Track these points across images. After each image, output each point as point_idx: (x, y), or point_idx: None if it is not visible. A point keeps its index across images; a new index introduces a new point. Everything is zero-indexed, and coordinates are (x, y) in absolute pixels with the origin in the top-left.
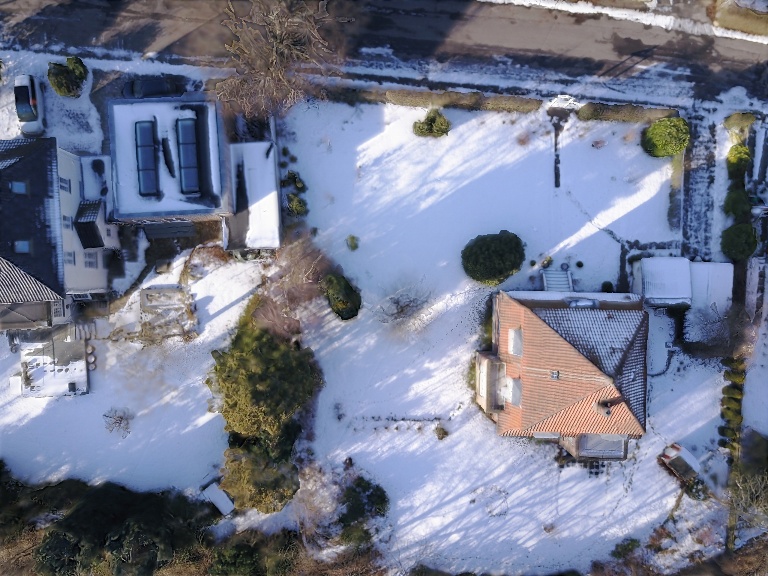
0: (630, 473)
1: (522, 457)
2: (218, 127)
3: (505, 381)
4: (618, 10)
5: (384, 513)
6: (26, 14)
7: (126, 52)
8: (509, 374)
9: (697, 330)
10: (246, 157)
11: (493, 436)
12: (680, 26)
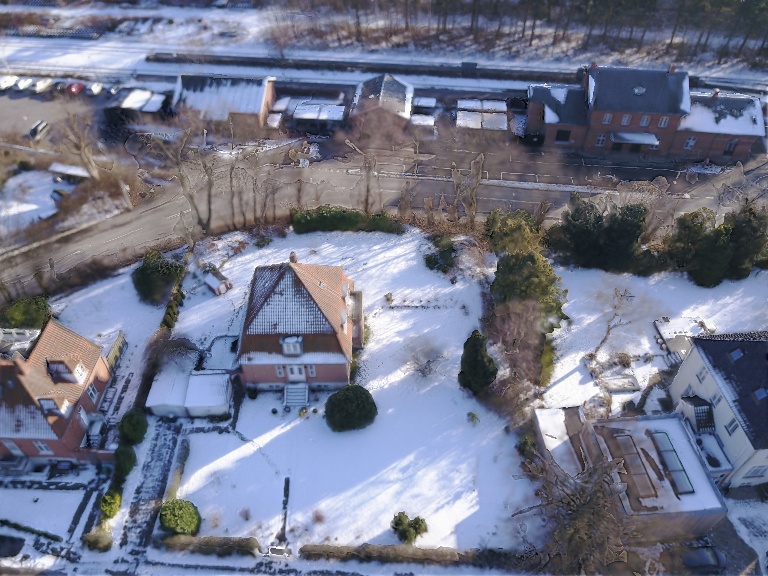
0: None
1: None
2: None
3: None
4: None
5: None
6: None
7: None
8: (347, 308)
9: None
10: None
11: None
12: None
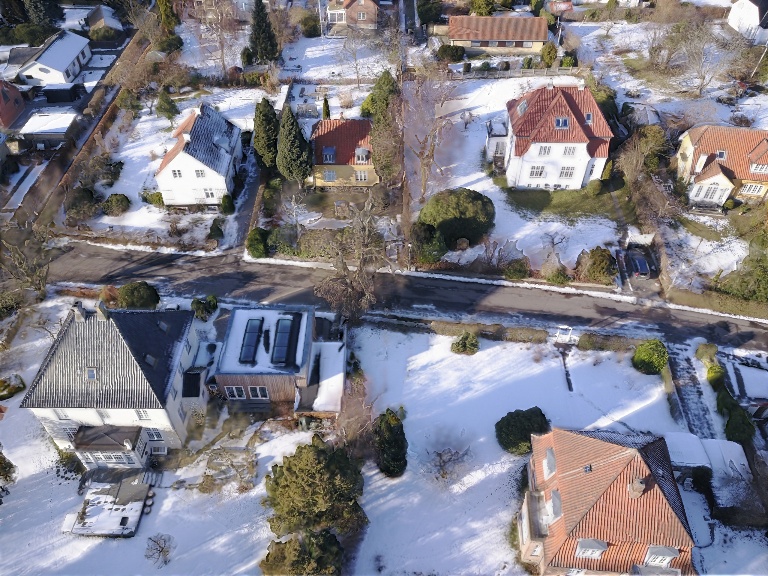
0: None
1: None
2: (307, 325)
3: (546, 512)
4: (594, 292)
5: None
6: (186, 280)
7: (247, 301)
8: (548, 498)
9: (727, 494)
10: (323, 351)
11: None
12: (642, 302)
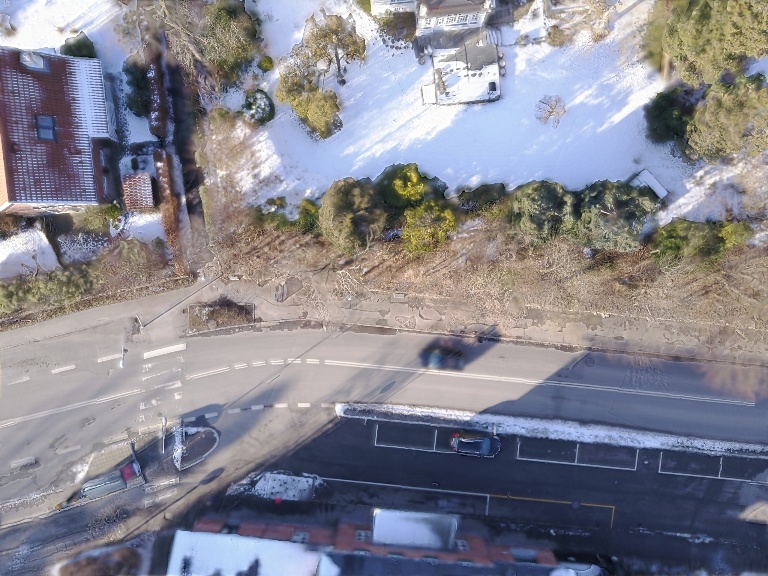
0: None
1: None
2: None
3: None
4: None
5: None
6: None
7: None
8: None
9: None
10: None
11: None
12: None
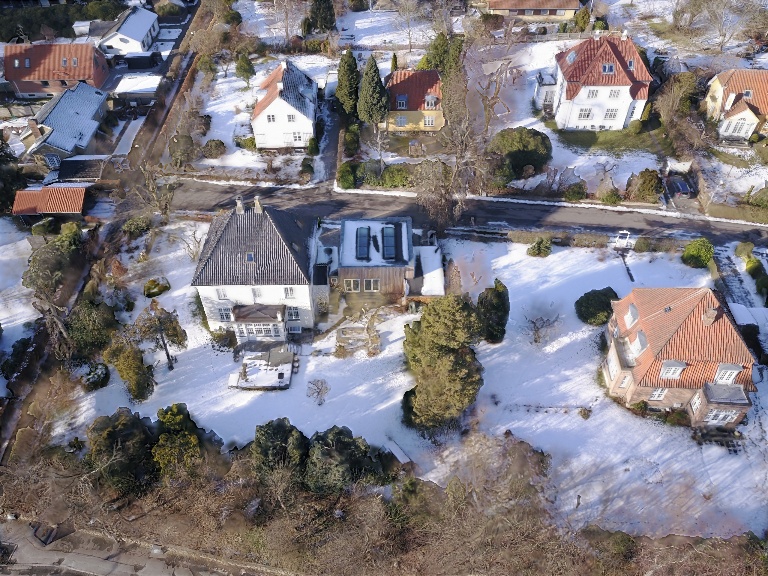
0: (766, 451)
1: (662, 435)
2: (408, 231)
3: (631, 352)
4: (643, 210)
5: (547, 474)
6: (287, 207)
7: None
8: (633, 340)
9: None
10: (422, 252)
11: (631, 419)
12: (685, 216)
